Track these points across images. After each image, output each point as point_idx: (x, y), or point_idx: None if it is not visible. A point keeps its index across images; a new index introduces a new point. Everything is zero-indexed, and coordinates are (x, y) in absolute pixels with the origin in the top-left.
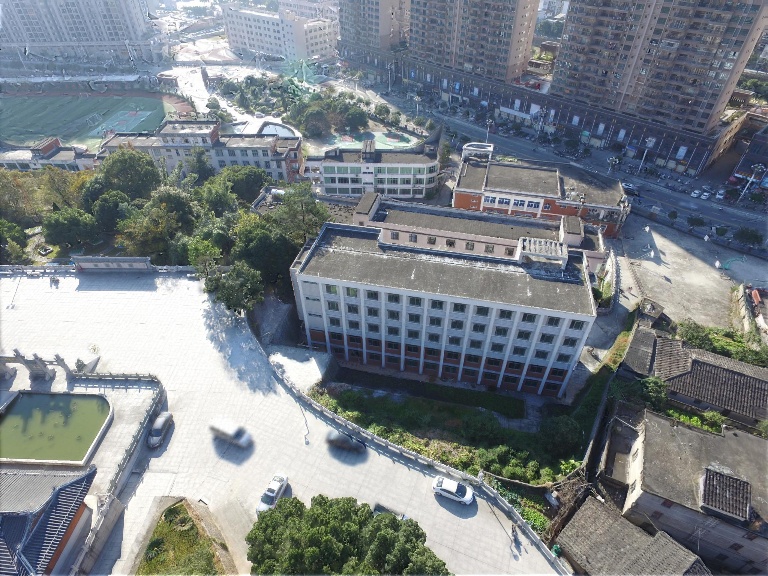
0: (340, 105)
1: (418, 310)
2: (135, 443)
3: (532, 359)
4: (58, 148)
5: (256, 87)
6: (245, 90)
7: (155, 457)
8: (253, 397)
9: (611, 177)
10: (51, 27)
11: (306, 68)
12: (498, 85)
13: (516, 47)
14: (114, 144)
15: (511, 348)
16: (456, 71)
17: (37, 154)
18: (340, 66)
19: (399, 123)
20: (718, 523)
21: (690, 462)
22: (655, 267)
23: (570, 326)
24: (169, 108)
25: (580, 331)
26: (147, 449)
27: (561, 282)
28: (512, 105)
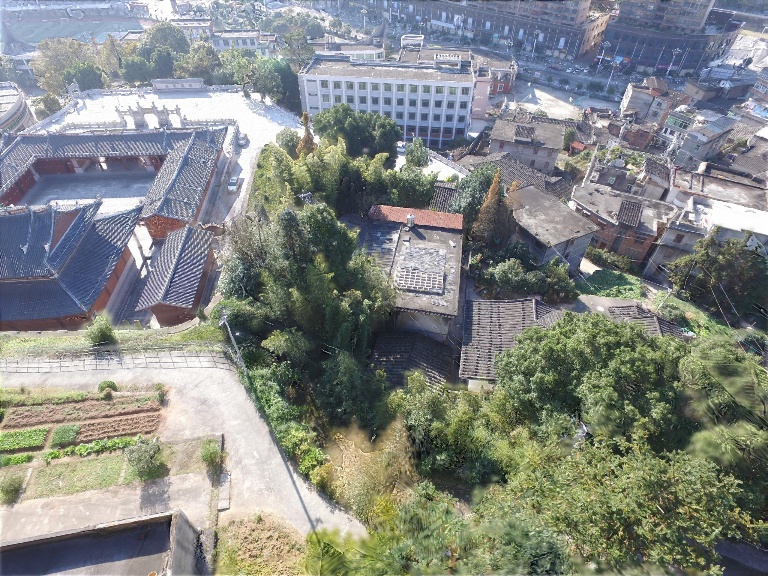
0: (300, 19)
1: (377, 94)
2: (233, 141)
3: (444, 123)
4: None
5: (224, 9)
6: (214, 12)
7: (244, 149)
8: None
9: (507, 54)
10: None
11: None
12: (428, 1)
13: None
14: (131, 38)
15: (432, 116)
16: None
17: None
18: None
19: (350, 33)
20: (523, 149)
21: (513, 130)
22: (533, 106)
23: (462, 93)
24: None
25: (468, 96)
26: (238, 147)
27: (458, 74)
28: (440, 17)
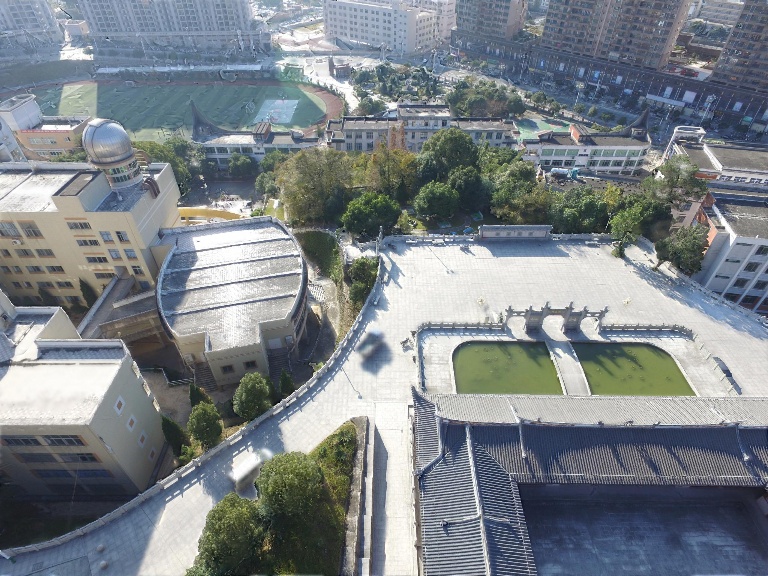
0: (498, 93)
1: None
2: None
3: None
4: (270, 133)
5: None
6: (385, 79)
7: None
8: (767, 344)
9: None
10: (162, 16)
11: (436, 57)
12: (648, 73)
13: (673, 36)
14: (351, 127)
15: None
16: (598, 60)
17: (259, 138)
18: (455, 56)
19: None
20: None
21: None
22: None
23: None
24: (313, 96)
25: None
26: None
27: None
28: (662, 92)
